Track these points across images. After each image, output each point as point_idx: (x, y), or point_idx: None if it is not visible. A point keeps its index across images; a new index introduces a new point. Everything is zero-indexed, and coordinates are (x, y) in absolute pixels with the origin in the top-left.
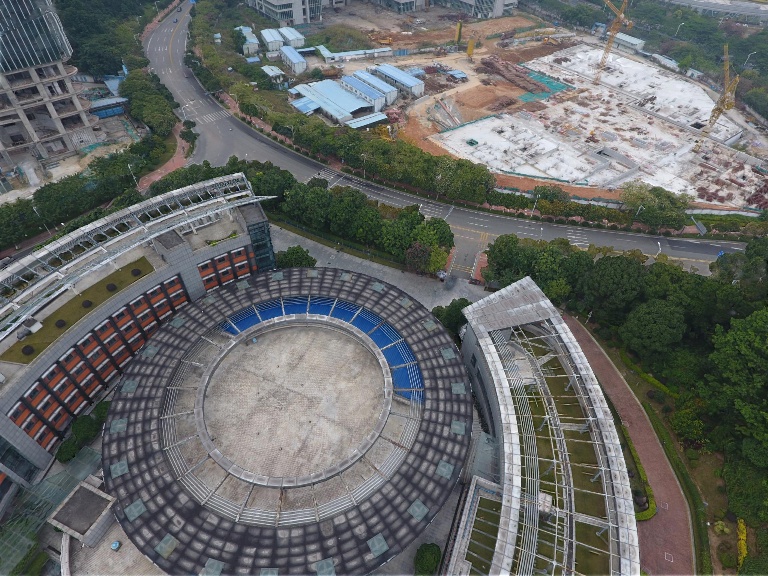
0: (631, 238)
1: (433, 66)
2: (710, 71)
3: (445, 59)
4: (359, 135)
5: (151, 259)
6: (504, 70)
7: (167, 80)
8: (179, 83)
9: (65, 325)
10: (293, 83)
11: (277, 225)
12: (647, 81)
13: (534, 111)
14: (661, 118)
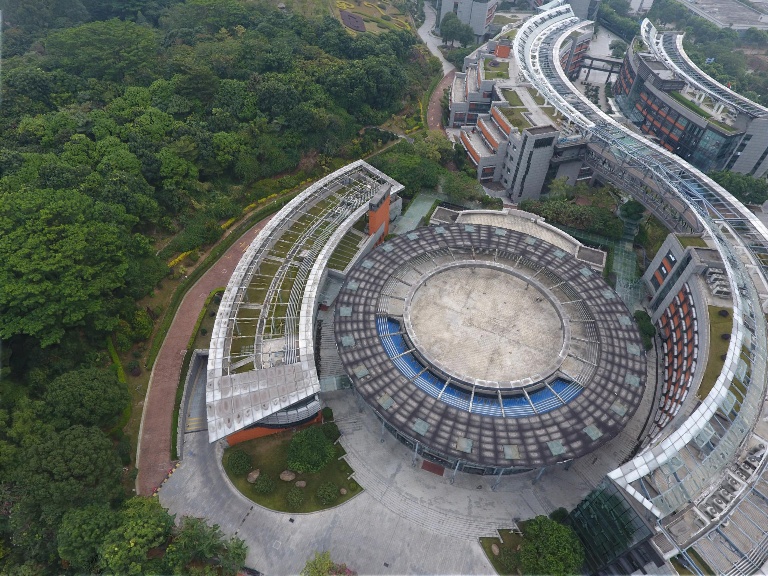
0: None
1: None
2: None
3: None
4: None
5: None
6: None
7: None
8: None
9: (721, 337)
10: None
11: None
12: None
13: None
14: None
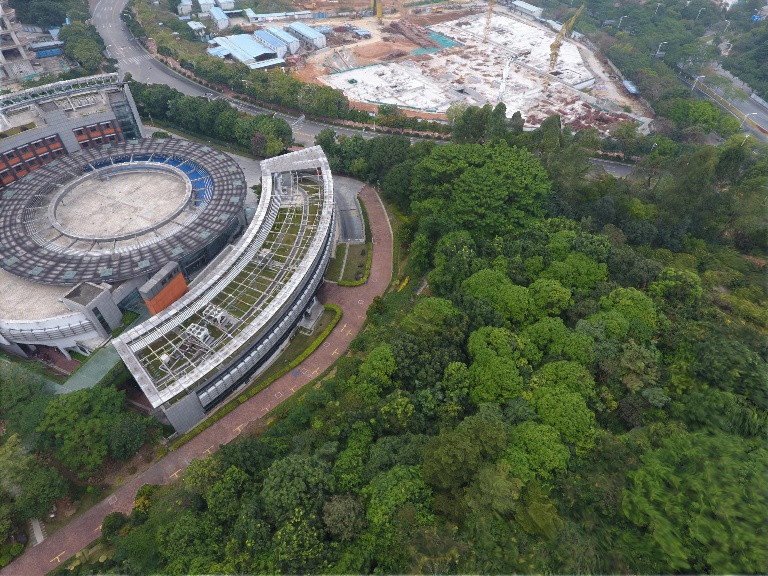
0: None
1: (344, 26)
2: (590, 33)
3: (359, 22)
4: (248, 69)
5: (38, 123)
6: (406, 30)
7: (105, 32)
8: (115, 34)
9: None
10: (215, 37)
11: (165, 130)
12: (531, 40)
13: (419, 61)
14: (528, 68)
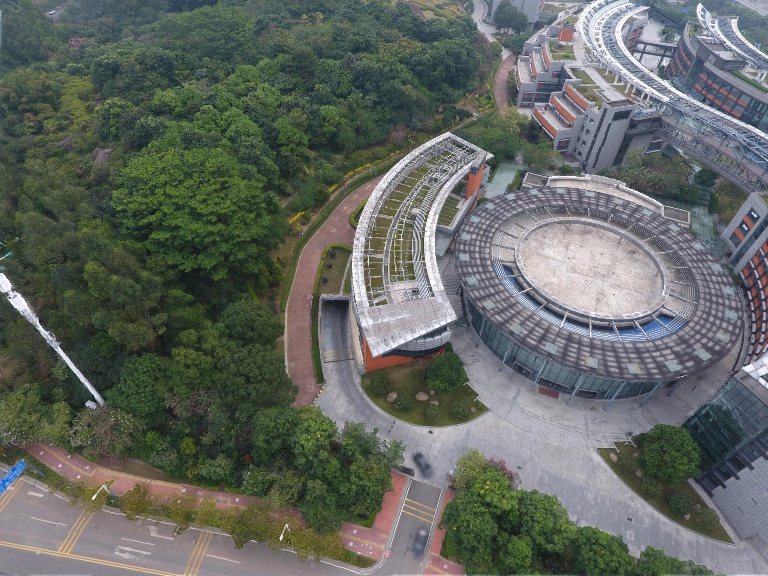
0: None
1: None
2: None
3: None
4: None
5: None
6: None
7: None
8: None
9: None
10: None
11: None
12: None
13: None
14: None
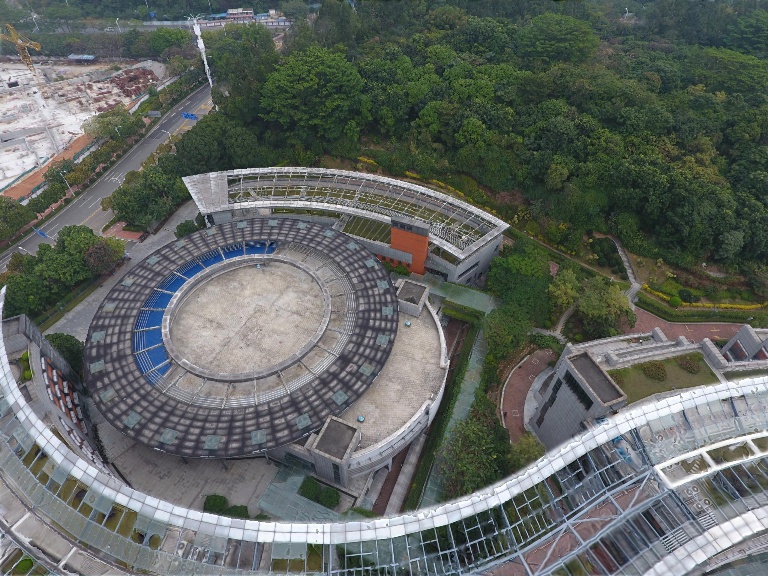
0: (135, 152)
1: None
2: None
3: None
4: None
5: None
6: None
7: None
8: None
9: None
10: None
11: None
12: None
13: None
14: None
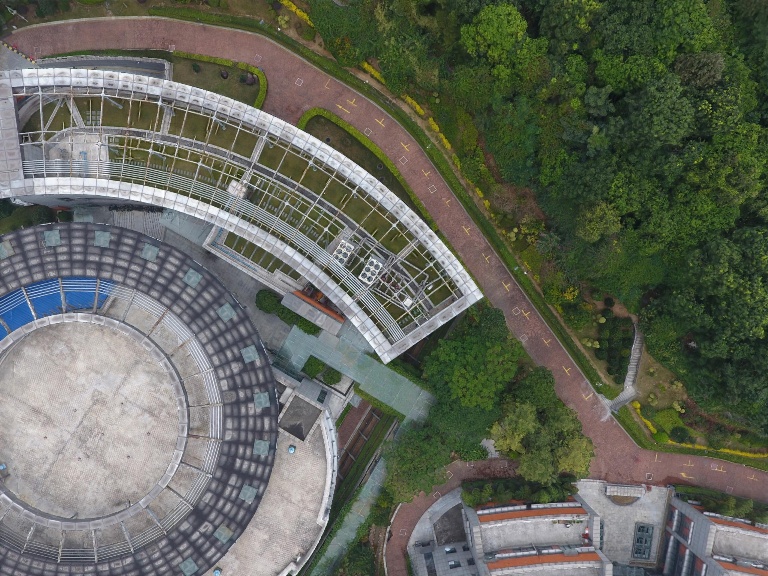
0: None
1: None
2: None
3: None
4: None
5: None
6: None
7: None
8: None
9: None
10: None
11: None
12: None
13: None
14: None
